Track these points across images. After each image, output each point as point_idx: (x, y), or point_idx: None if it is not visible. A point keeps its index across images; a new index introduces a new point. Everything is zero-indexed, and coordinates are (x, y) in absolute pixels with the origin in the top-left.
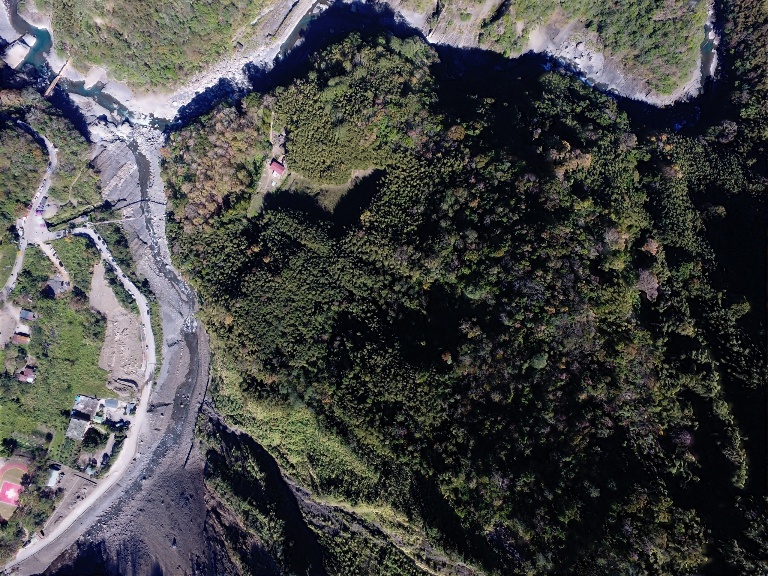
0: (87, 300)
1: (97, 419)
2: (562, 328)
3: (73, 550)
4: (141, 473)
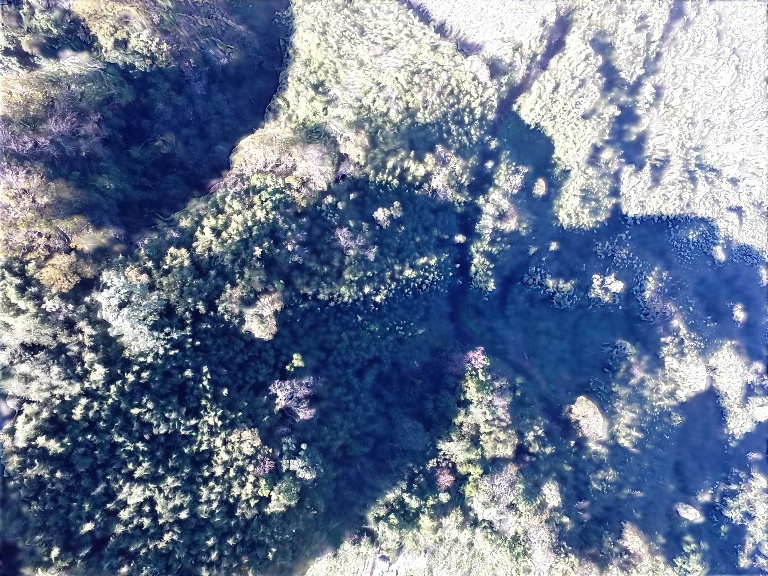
0: None
1: None
2: (747, 1)
3: None
4: None
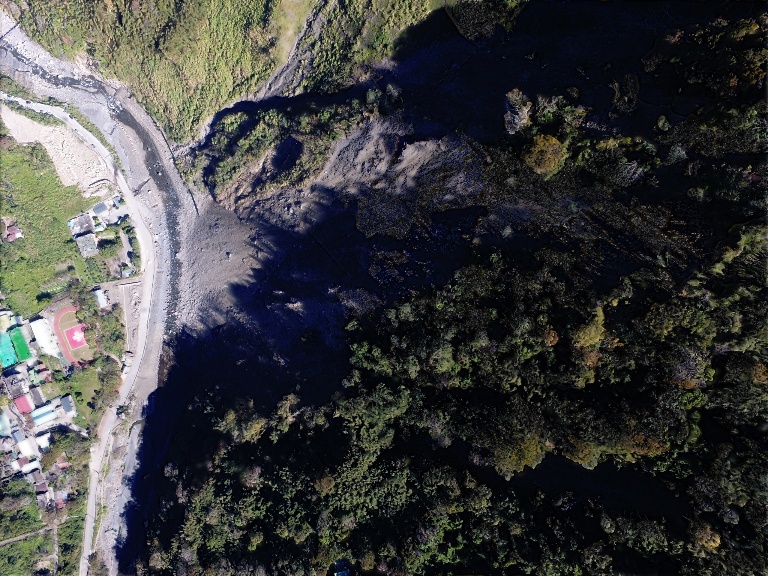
0: (12, 139)
1: (98, 228)
2: None
3: (166, 351)
4: (171, 251)
